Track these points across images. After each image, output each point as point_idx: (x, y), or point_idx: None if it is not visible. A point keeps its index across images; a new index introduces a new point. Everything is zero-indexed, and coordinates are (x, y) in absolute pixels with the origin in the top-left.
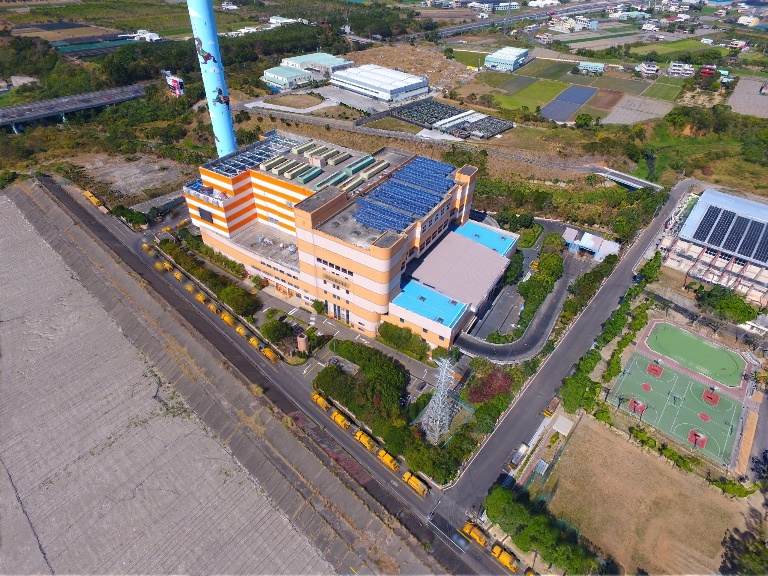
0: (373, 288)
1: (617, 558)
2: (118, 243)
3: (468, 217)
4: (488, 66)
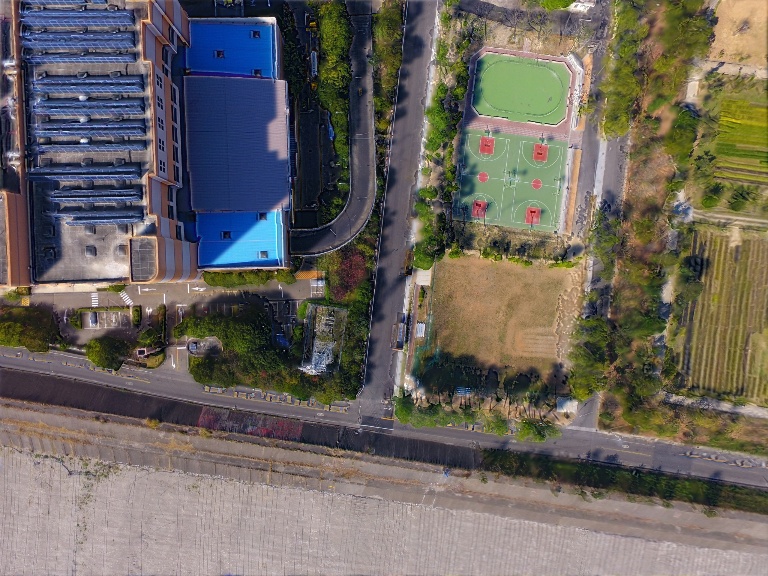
0: None
1: (491, 368)
2: None
3: (185, 18)
4: None
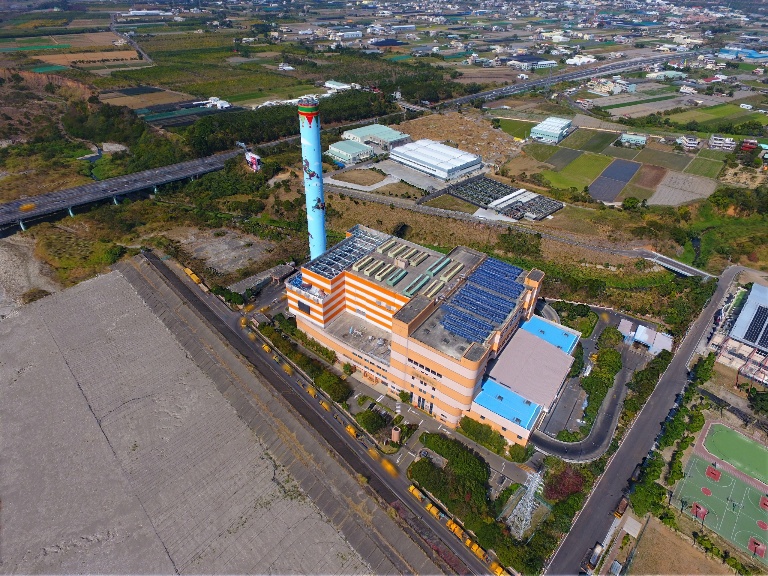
0: (460, 390)
1: None
2: (221, 323)
3: (533, 312)
4: (534, 137)
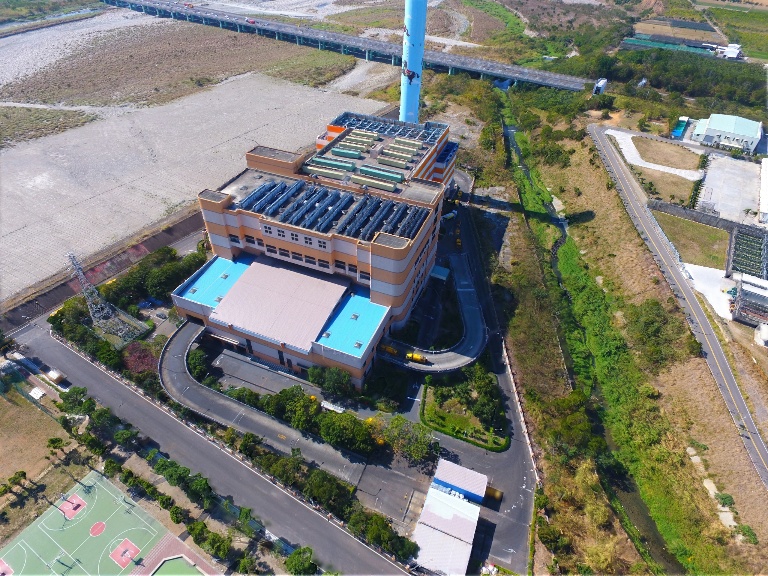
0: None
1: None
2: None
3: (390, 303)
4: None
